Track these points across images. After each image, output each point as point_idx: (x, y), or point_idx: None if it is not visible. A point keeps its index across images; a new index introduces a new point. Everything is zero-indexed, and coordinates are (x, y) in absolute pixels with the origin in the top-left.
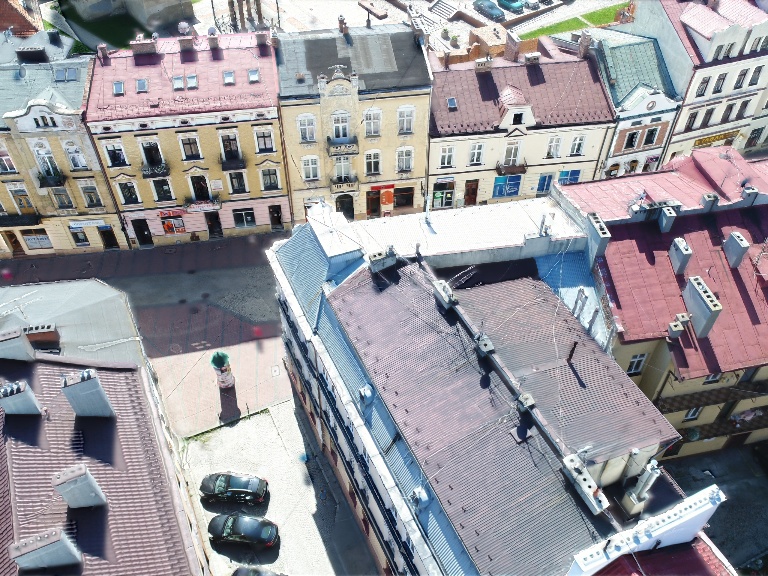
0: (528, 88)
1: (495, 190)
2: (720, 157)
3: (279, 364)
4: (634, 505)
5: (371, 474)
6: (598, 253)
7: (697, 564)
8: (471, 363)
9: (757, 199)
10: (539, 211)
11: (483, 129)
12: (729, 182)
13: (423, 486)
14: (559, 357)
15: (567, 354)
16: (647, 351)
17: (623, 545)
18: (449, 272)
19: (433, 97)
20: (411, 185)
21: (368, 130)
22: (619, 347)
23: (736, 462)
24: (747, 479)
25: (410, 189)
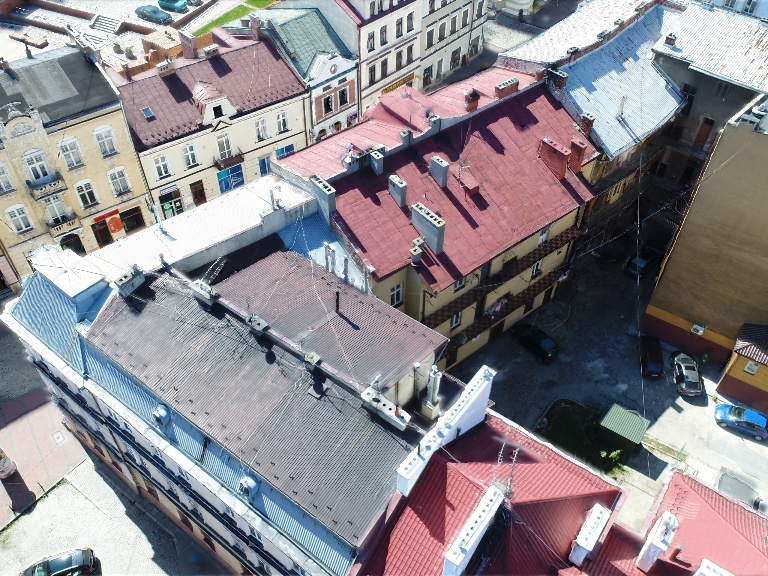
0: (217, 80)
1: (221, 186)
2: (402, 97)
3: (60, 429)
4: (432, 411)
5: (195, 489)
6: (330, 210)
7: (495, 436)
8: (252, 346)
9: (442, 124)
10: (266, 189)
11: (188, 130)
12: (416, 116)
13: (247, 474)
14: (328, 311)
15: (334, 306)
16: (401, 281)
17: (432, 444)
18: (201, 271)
19: (126, 112)
20: (136, 205)
21: (69, 162)
22: (377, 286)
23: (502, 349)
24: (515, 359)
25: (136, 209)
